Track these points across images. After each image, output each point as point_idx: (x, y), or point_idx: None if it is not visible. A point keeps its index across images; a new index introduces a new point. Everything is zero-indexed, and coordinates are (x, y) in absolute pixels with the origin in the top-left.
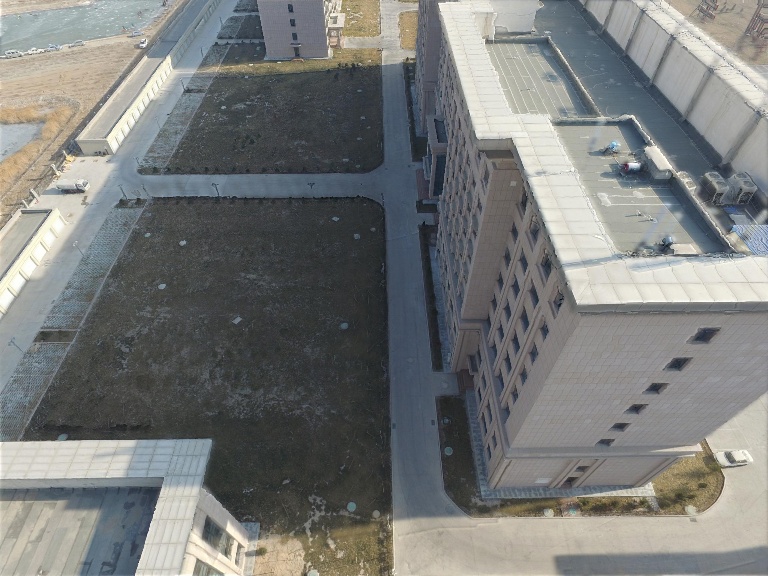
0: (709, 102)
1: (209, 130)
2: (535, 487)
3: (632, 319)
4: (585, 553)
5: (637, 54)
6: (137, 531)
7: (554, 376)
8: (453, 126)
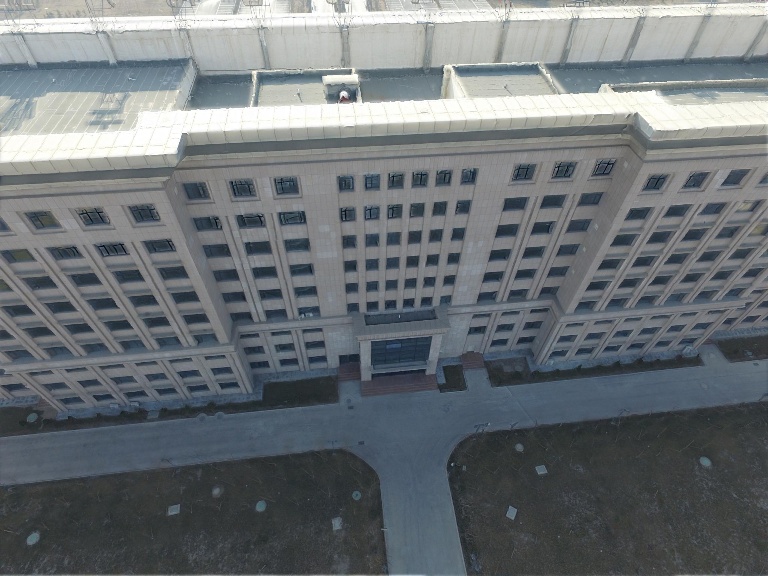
0: (714, 34)
1: None
2: None
3: None
4: None
5: (583, 55)
6: None
7: None
8: (634, 230)
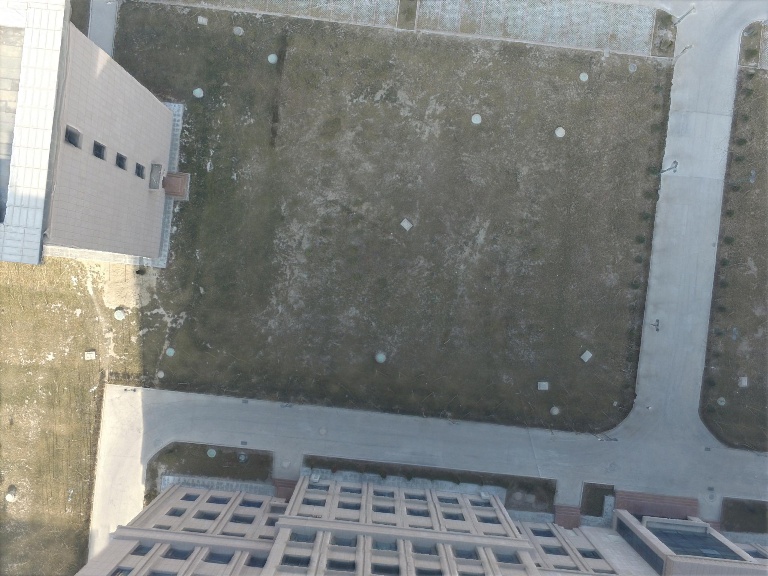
0: None
1: None
2: None
3: None
4: None
5: None
6: (4, 197)
7: None
8: None
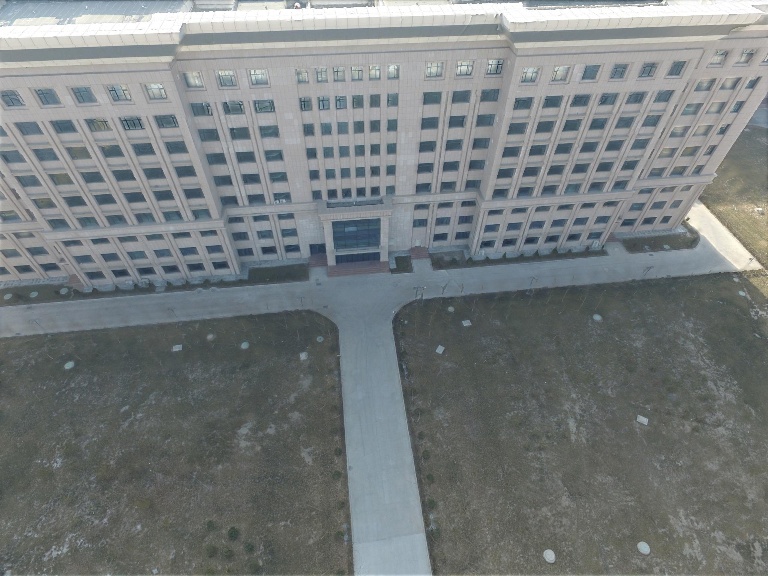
0: None
1: None
2: None
3: None
4: None
5: None
6: None
7: None
8: (523, 118)
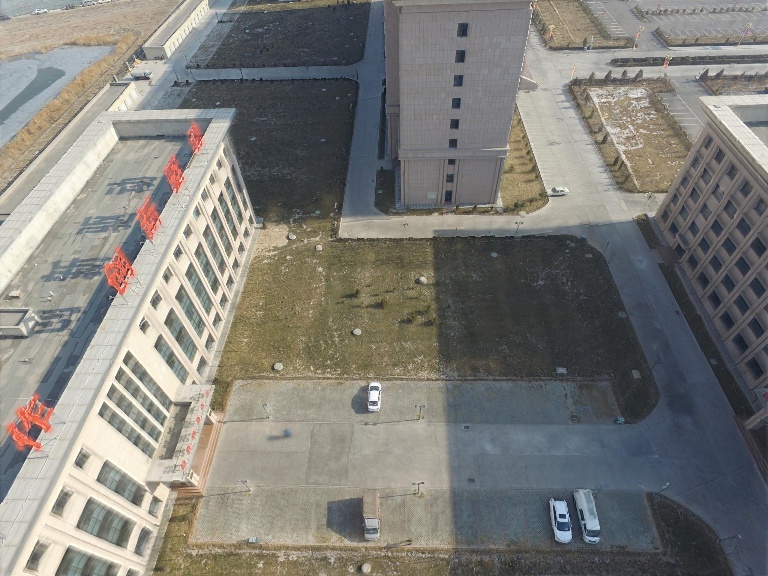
0: None
1: (236, 44)
2: (429, 204)
3: (424, 16)
4: (452, 229)
5: None
6: None
7: (402, 68)
8: None
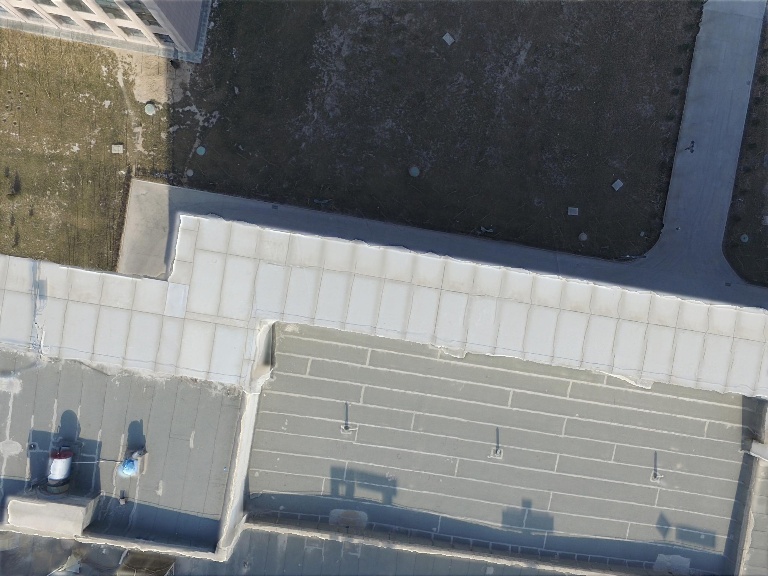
0: None
1: None
2: None
3: None
4: None
5: None
6: None
7: None
8: None
